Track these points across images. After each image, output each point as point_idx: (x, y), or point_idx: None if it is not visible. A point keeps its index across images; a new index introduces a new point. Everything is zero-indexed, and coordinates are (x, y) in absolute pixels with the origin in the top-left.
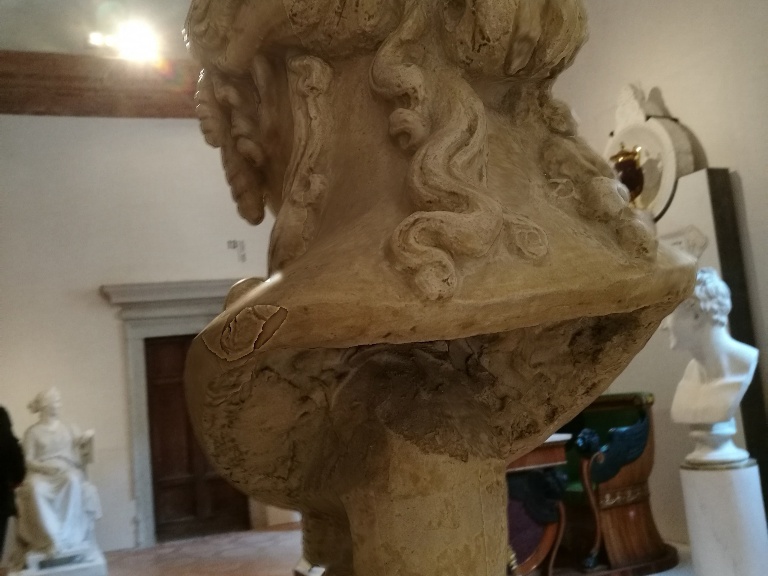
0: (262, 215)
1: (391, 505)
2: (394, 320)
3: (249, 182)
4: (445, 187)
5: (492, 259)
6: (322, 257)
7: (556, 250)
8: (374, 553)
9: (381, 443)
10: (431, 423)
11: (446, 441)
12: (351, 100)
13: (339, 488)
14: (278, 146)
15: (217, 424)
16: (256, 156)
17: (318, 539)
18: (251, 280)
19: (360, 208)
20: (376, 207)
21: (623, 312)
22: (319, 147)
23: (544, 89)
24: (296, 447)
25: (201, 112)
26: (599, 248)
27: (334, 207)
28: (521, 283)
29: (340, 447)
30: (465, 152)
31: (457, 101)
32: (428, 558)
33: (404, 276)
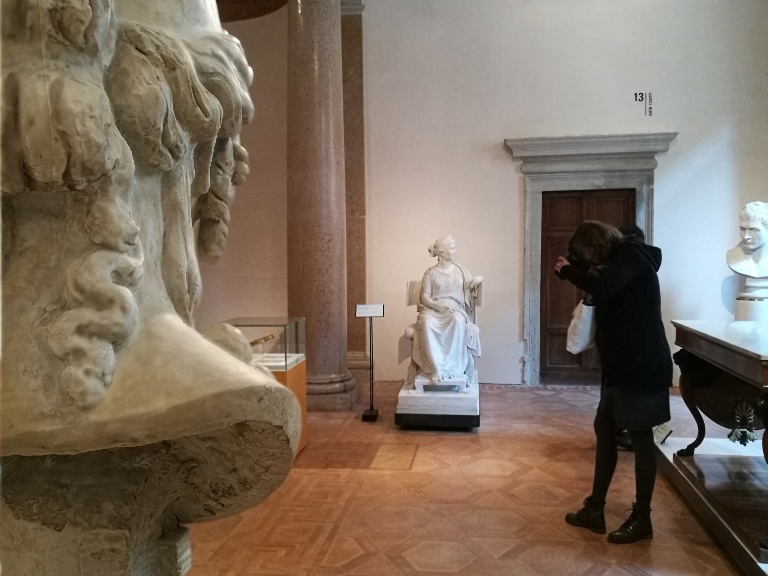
0: None
1: (1, 552)
2: None
3: None
4: None
5: None
6: None
7: None
8: None
9: None
10: (38, 491)
11: (44, 510)
12: None
13: None
14: None
15: None
16: None
17: None
18: None
19: None
20: None
21: None
22: None
23: (91, 195)
24: None
25: None
26: (35, 391)
27: None
28: None
29: None
30: None
31: None
32: None
33: None
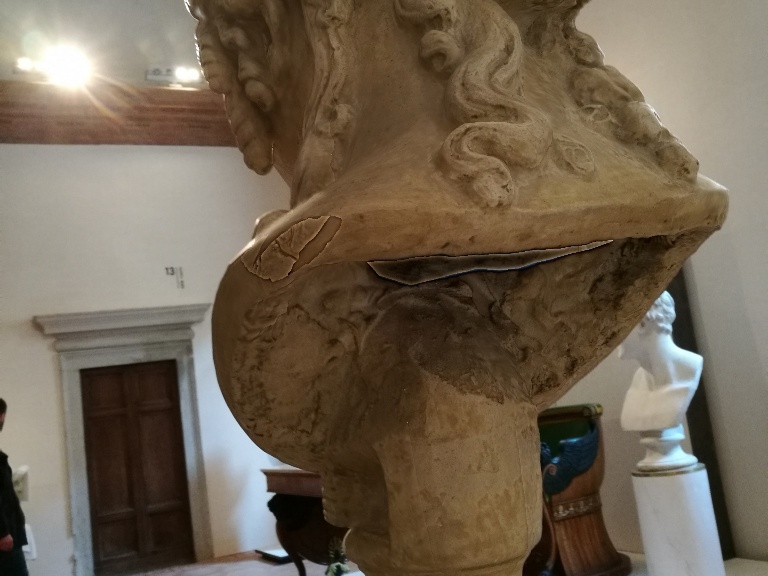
0: (271, 164)
1: (429, 449)
2: (453, 228)
3: (258, 129)
4: (491, 101)
5: (543, 173)
6: (367, 172)
7: (602, 168)
8: (412, 501)
9: (416, 385)
10: (465, 364)
11: (481, 382)
12: (375, 30)
13: (371, 436)
14: (290, 89)
15: (247, 365)
16: (267, 99)
17: (344, 497)
18: (280, 211)
19: (397, 130)
20: (415, 127)
21: (667, 234)
22: (344, 77)
23: (568, 21)
24: (321, 398)
25: (206, 56)
26: (642, 168)
27: (365, 134)
28: (575, 196)
29: (369, 394)
30: (505, 70)
31: (491, 22)
32: (469, 504)
33: (460, 185)
